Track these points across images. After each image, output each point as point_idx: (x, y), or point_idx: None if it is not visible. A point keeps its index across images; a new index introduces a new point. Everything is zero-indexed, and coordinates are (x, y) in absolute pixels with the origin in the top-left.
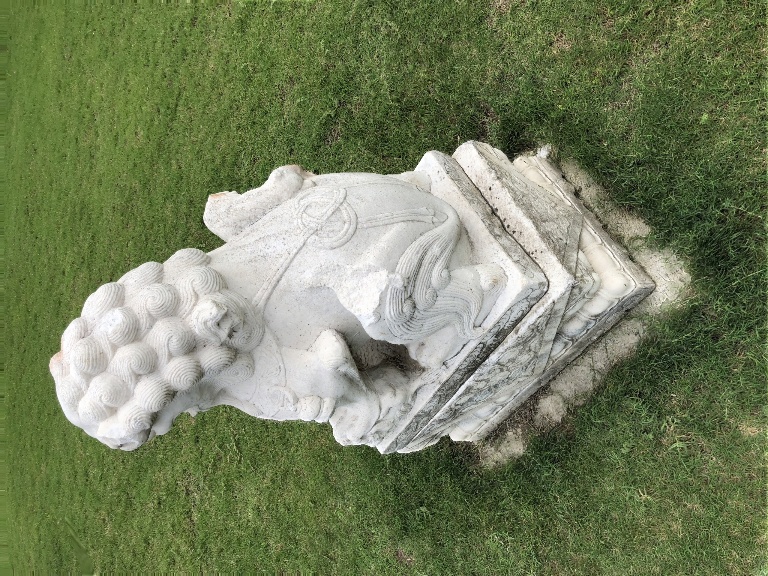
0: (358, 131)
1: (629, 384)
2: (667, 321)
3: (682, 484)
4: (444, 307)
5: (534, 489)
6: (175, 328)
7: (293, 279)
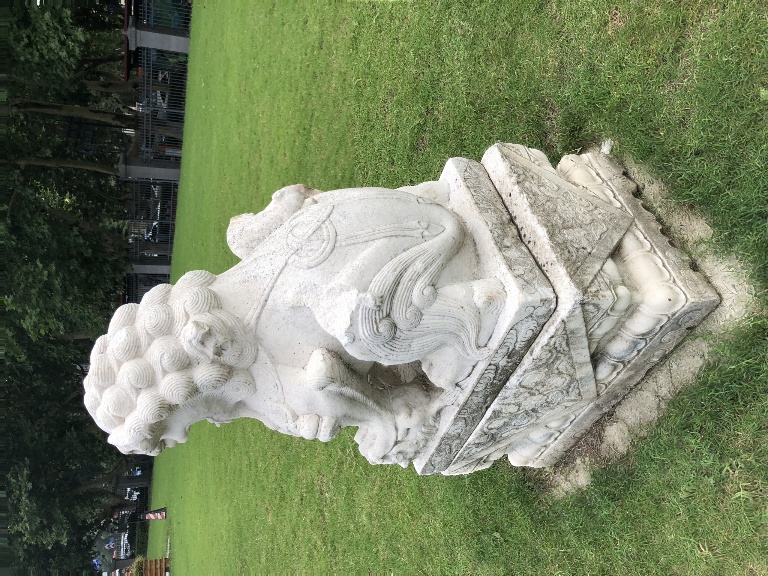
0: (442, 138)
1: (690, 416)
2: (727, 343)
3: (747, 543)
4: (432, 326)
5: (594, 528)
6: (167, 346)
7: (278, 299)
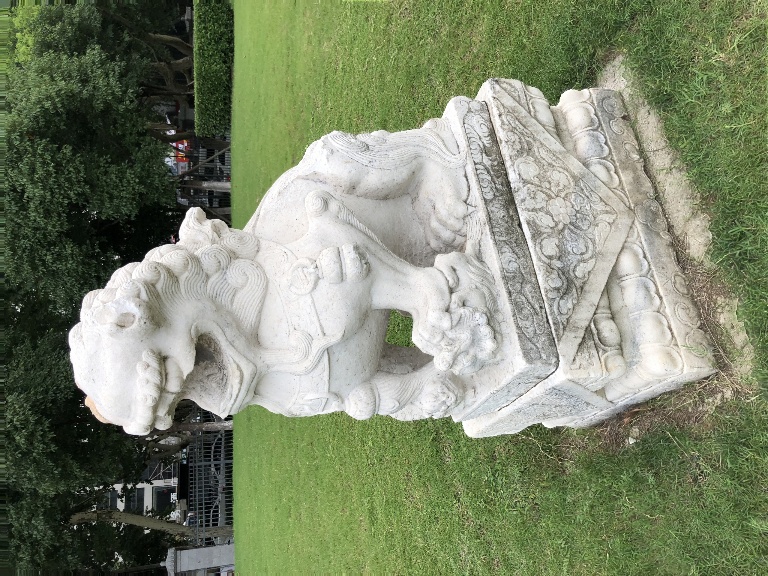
0: None
1: None
2: (630, 66)
3: None
4: None
5: (767, 267)
6: None
7: (267, 204)
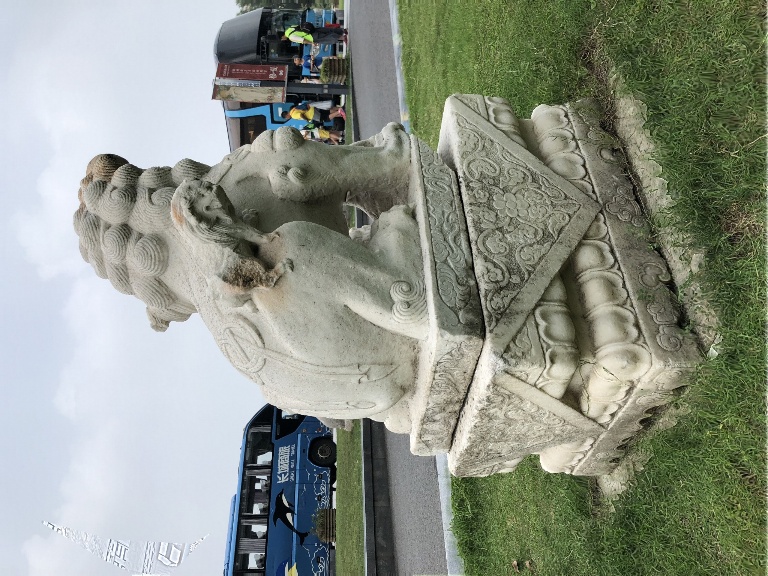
0: None
1: None
2: (576, 483)
3: None
4: None
5: None
6: None
7: None
